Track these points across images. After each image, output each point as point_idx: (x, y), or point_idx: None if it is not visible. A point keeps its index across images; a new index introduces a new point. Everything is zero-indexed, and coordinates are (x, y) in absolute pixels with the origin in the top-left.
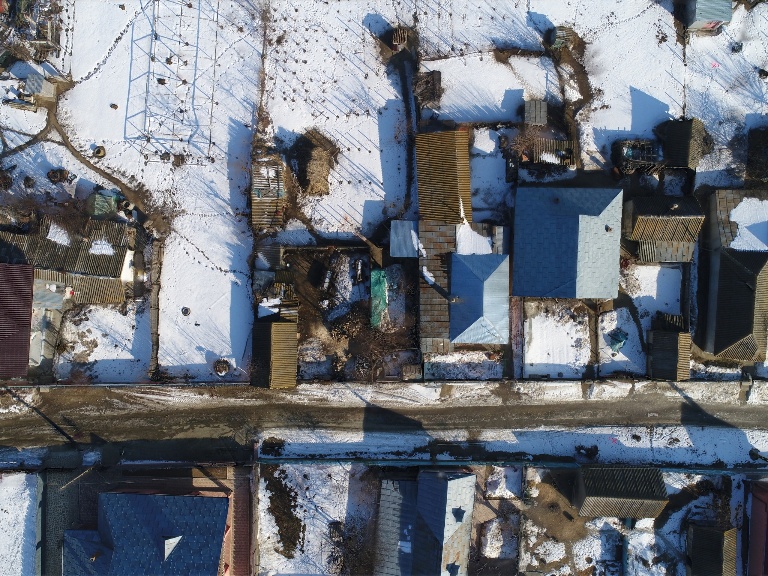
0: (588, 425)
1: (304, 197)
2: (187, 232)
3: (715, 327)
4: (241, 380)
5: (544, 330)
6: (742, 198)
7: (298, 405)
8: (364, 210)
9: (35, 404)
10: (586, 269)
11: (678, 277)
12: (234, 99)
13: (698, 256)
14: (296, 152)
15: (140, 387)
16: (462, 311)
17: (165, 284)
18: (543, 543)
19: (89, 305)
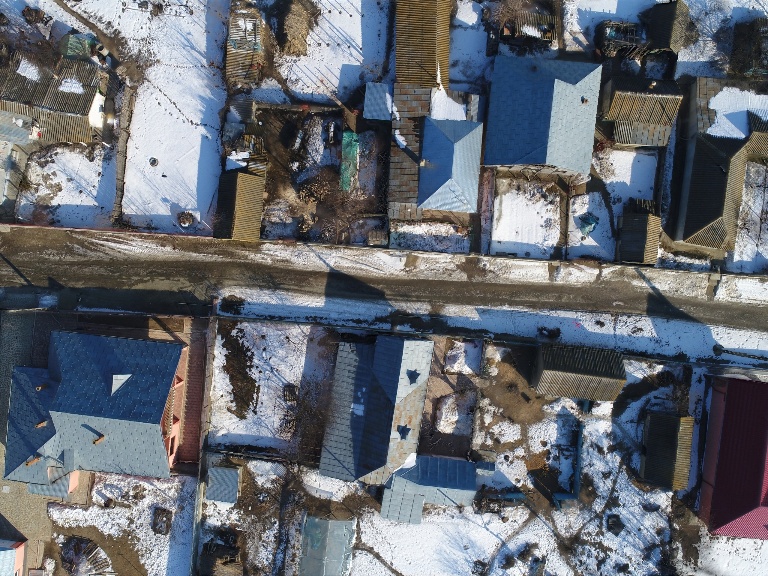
0: (552, 308)
1: (281, 57)
2: (160, 82)
3: (686, 212)
4: (205, 235)
5: (514, 207)
6: (723, 87)
7: (261, 265)
8: (341, 74)
9: None
10: (558, 136)
11: (653, 164)
12: None
13: (675, 145)
14: (276, 10)
15: (102, 234)
16: (431, 175)
17: (134, 133)
18: (499, 423)
19: (56, 148)
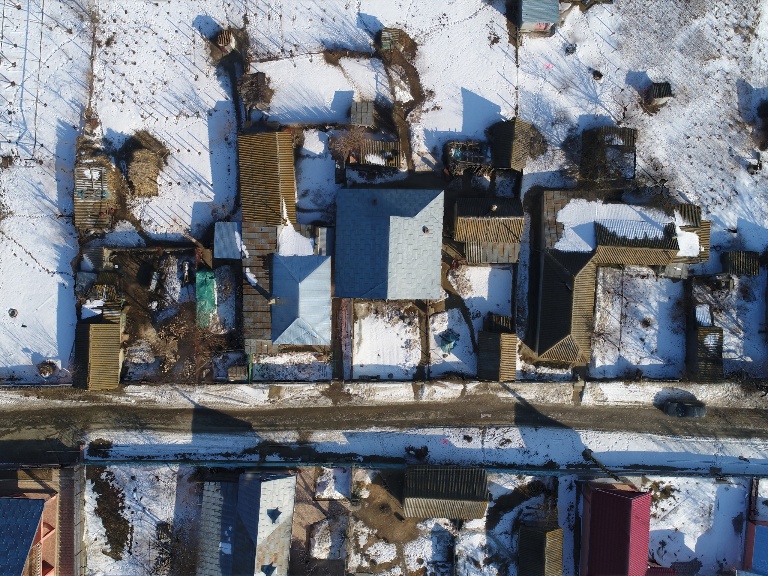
0: (420, 426)
1: (133, 198)
2: (14, 234)
3: (539, 328)
4: (67, 382)
5: (374, 331)
6: (570, 199)
7: (126, 406)
8: (193, 211)
9: None
10: (400, 270)
11: (509, 278)
12: (62, 101)
13: (529, 257)
14: (125, 153)
15: None
16: (282, 312)
17: None
18: (374, 544)
19: None
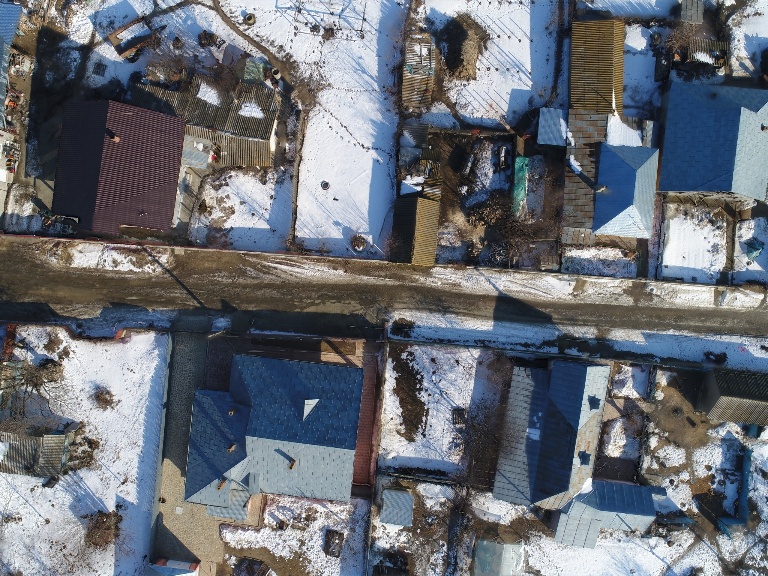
0: (717, 333)
1: (451, 81)
2: (332, 106)
3: None
4: (376, 258)
5: (682, 232)
6: None
7: (430, 288)
8: (510, 98)
9: (169, 266)
10: (742, 164)
11: None
12: None
13: None
14: (446, 35)
15: (275, 257)
16: (609, 201)
17: (306, 156)
18: (664, 447)
19: (230, 171)
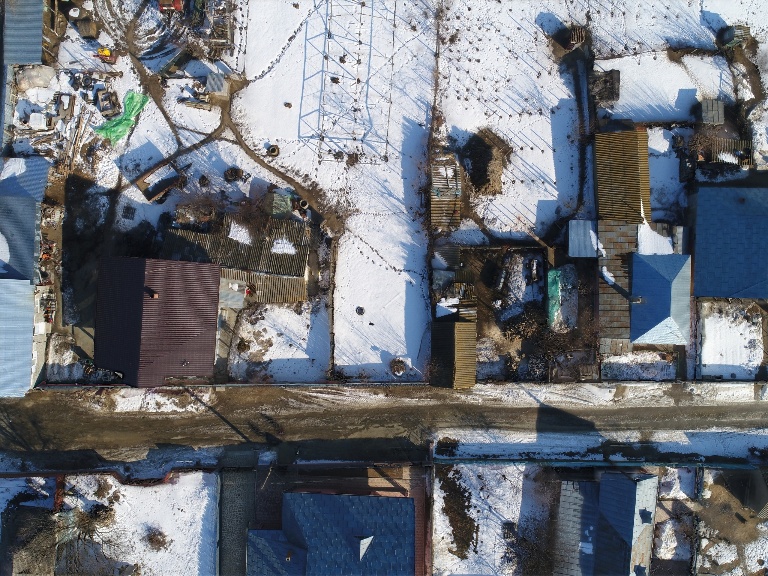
0: (759, 426)
1: (477, 196)
2: (361, 231)
3: None
4: (416, 380)
5: (718, 331)
6: None
7: (472, 405)
8: (537, 210)
9: (211, 403)
10: None
11: None
12: (408, 98)
13: None
14: (469, 151)
15: (316, 387)
16: (645, 311)
17: (339, 283)
18: (715, 545)
19: (265, 304)
